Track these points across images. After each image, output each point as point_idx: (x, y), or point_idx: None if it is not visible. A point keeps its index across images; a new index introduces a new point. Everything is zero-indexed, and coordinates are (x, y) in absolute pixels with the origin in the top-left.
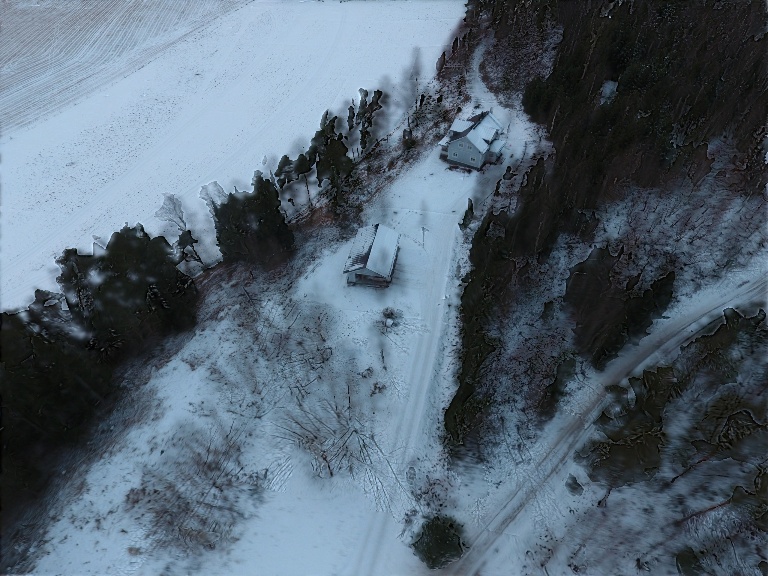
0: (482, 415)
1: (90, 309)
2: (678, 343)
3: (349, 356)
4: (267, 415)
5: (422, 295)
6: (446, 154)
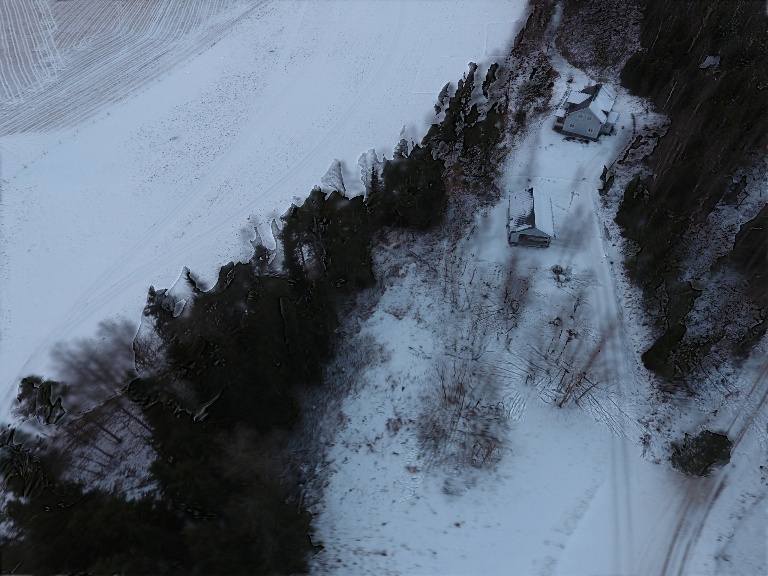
0: (717, 348)
1: (312, 262)
2: None
3: (536, 307)
4: (481, 358)
5: (583, 254)
6: (560, 125)
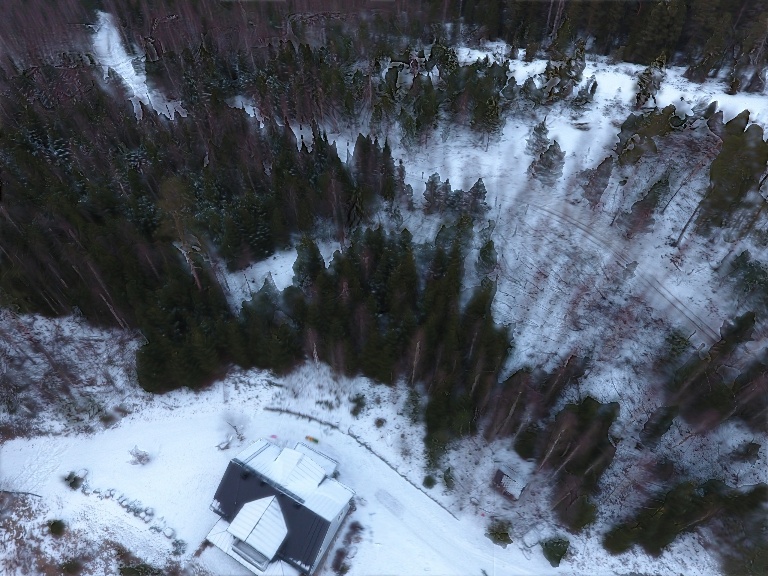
0: None
1: None
2: (718, 337)
3: None
4: None
5: None
6: None
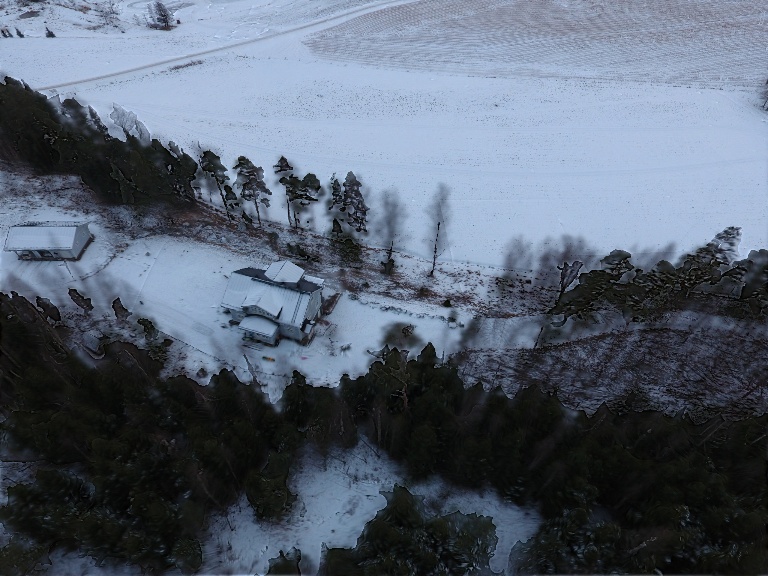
0: None
1: None
2: None
3: None
4: None
5: None
6: None
